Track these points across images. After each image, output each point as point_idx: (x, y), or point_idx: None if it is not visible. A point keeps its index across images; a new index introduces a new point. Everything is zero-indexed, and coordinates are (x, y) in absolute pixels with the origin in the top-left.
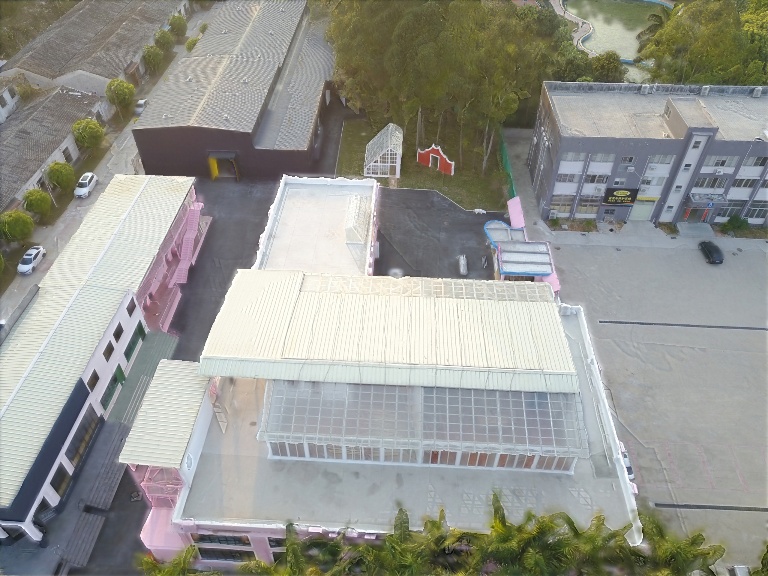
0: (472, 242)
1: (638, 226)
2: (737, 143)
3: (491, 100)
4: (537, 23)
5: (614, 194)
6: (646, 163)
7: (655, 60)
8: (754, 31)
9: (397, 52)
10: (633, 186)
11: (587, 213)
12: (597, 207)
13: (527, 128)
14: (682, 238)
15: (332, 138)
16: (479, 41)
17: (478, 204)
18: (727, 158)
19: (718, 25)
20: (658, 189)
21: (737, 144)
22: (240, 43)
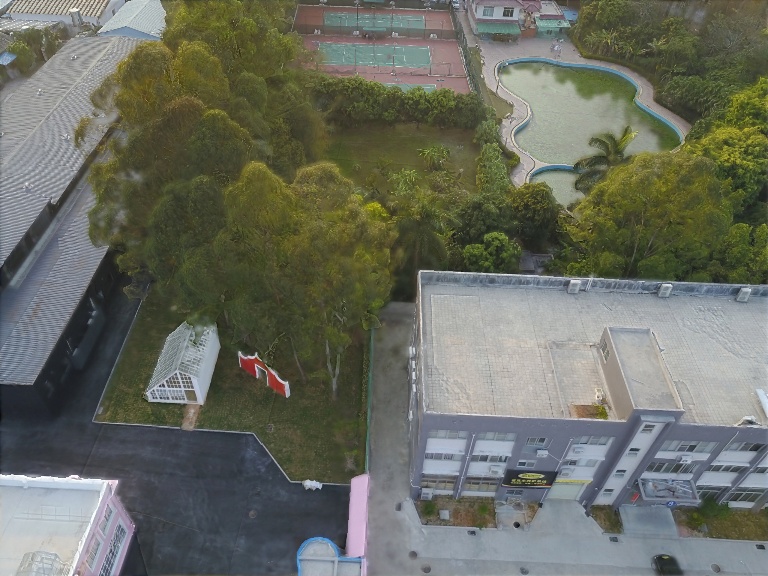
0: (284, 563)
1: (559, 512)
2: (714, 428)
3: (325, 317)
4: (455, 112)
5: (519, 476)
6: (567, 446)
7: (594, 224)
8: (736, 162)
9: (156, 251)
10: (548, 468)
11: (480, 491)
12: (495, 485)
13: (414, 301)
14: (626, 545)
15: (120, 321)
16: (280, 253)
17: (314, 465)
18: (698, 443)
19: (686, 199)
20: (589, 470)
21: (714, 429)
22: (9, 159)
